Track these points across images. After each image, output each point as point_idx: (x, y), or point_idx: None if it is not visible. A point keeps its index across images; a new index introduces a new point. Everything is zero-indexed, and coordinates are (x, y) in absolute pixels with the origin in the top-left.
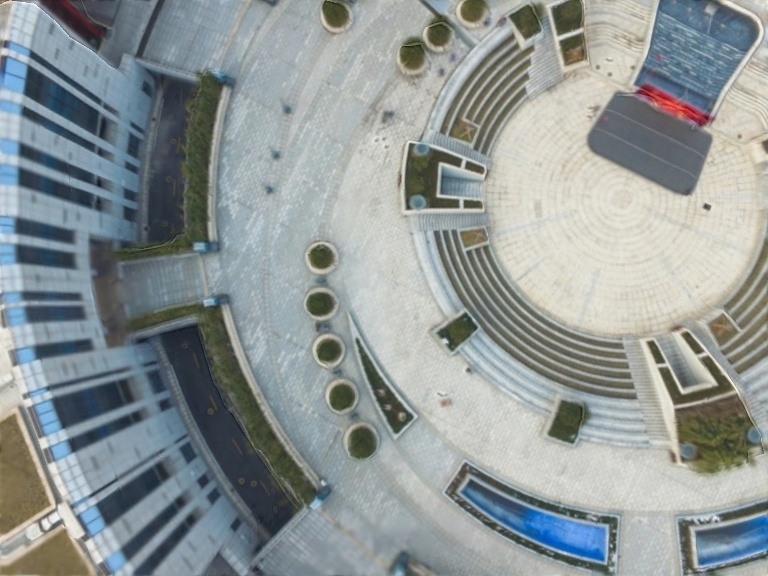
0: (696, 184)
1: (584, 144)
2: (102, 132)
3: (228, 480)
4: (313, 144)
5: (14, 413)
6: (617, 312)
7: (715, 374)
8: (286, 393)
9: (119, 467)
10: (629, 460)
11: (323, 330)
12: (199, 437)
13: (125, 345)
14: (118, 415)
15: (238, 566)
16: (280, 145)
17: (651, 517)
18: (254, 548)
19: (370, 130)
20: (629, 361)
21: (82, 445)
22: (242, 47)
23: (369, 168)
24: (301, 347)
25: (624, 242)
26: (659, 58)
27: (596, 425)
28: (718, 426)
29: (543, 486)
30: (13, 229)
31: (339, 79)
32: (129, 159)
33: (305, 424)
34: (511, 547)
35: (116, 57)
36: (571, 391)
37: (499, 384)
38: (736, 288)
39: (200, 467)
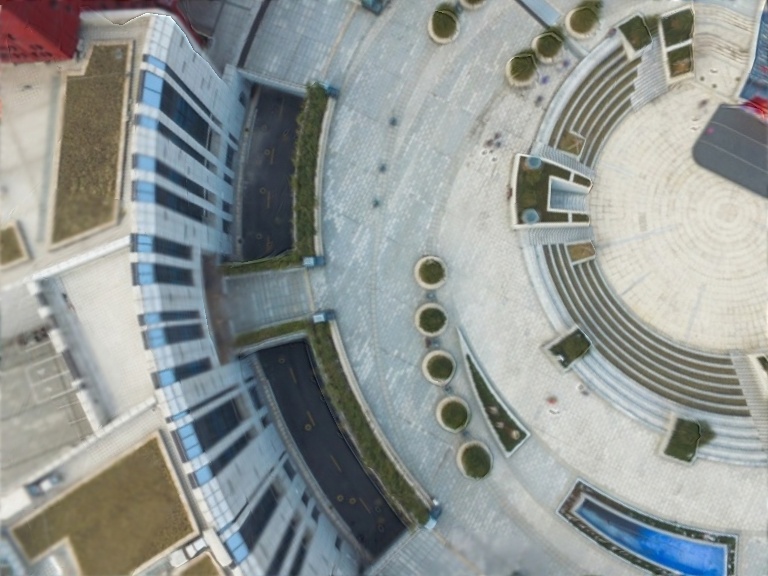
0: None
1: (689, 156)
2: (209, 144)
3: (326, 497)
4: (419, 156)
5: (155, 437)
6: (723, 327)
7: None
8: (395, 410)
9: (247, 489)
10: (746, 479)
11: (433, 346)
12: (297, 453)
13: (233, 362)
14: (237, 435)
15: None
16: (386, 157)
17: None
18: (363, 568)
19: (477, 142)
20: (739, 377)
21: (219, 469)
22: (346, 57)
23: (477, 181)
24: (409, 363)
25: (730, 256)
26: (764, 69)
27: (713, 443)
28: None
29: (659, 505)
30: (151, 248)
31: (445, 90)
32: (226, 171)
33: (414, 442)
34: (627, 567)
35: (219, 67)
36: (684, 408)
37: (613, 401)
38: None
39: (301, 484)
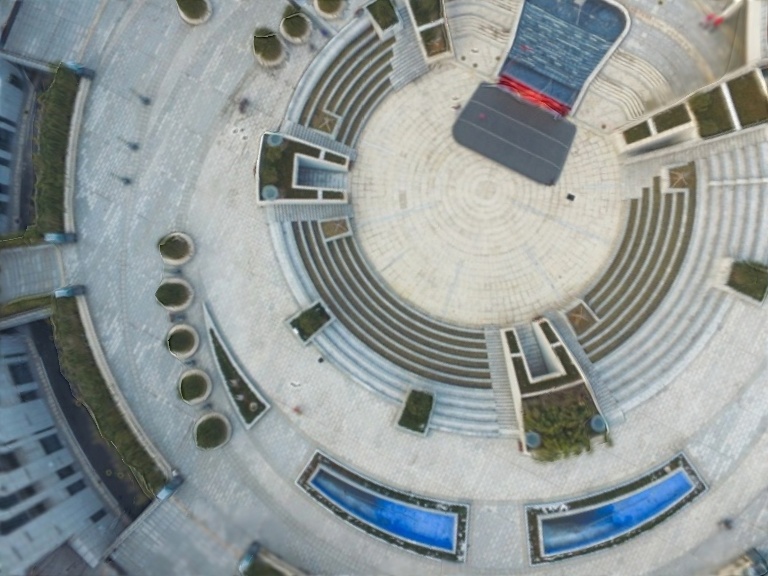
0: (560, 174)
1: (449, 135)
2: None
3: (95, 472)
4: (172, 135)
5: None
6: (480, 302)
7: (565, 363)
8: (141, 384)
9: None
10: (479, 449)
11: (177, 321)
12: (67, 429)
13: None
14: None
15: (89, 556)
16: (139, 136)
17: (500, 506)
18: (108, 539)
19: (228, 121)
20: (488, 351)
21: None
22: (102, 39)
23: (227, 159)
24: (157, 338)
25: (488, 233)
26: (524, 49)
27: (447, 415)
28: (558, 414)
29: (394, 476)
30: None
31: (198, 70)
32: None
33: (160, 415)
34: (362, 537)
35: None
36: (425, 381)
37: (351, 374)
38: (598, 278)
39: (64, 458)
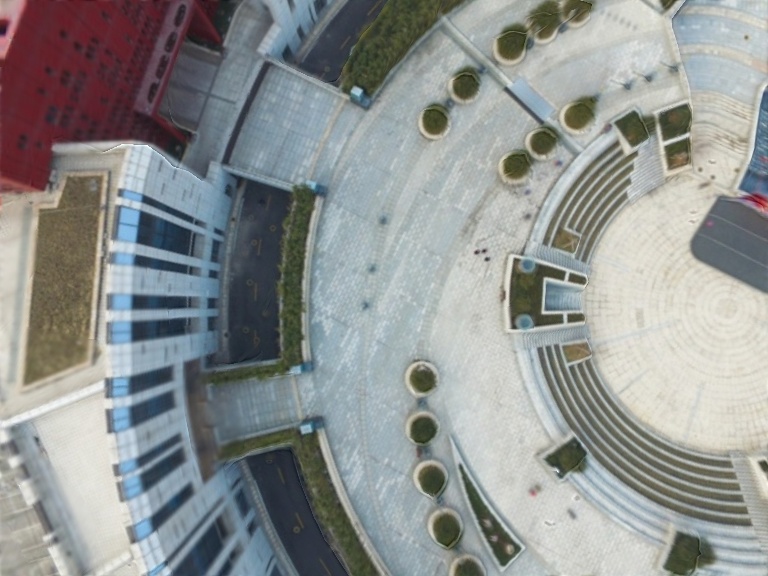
0: None
1: (687, 250)
2: (192, 249)
3: None
4: (410, 256)
5: None
6: (723, 427)
7: None
8: (385, 521)
9: None
10: None
11: (424, 456)
12: (285, 557)
13: (218, 475)
14: (220, 563)
15: None
16: (375, 257)
17: None
18: None
19: (469, 241)
20: (740, 482)
21: None
22: (334, 153)
23: (469, 282)
24: (400, 472)
25: (730, 353)
26: (763, 160)
27: (713, 557)
28: None
29: None
30: (127, 390)
31: (436, 187)
32: (211, 266)
33: (406, 555)
34: None
35: (203, 165)
36: (684, 518)
37: (610, 513)
38: None
39: None
